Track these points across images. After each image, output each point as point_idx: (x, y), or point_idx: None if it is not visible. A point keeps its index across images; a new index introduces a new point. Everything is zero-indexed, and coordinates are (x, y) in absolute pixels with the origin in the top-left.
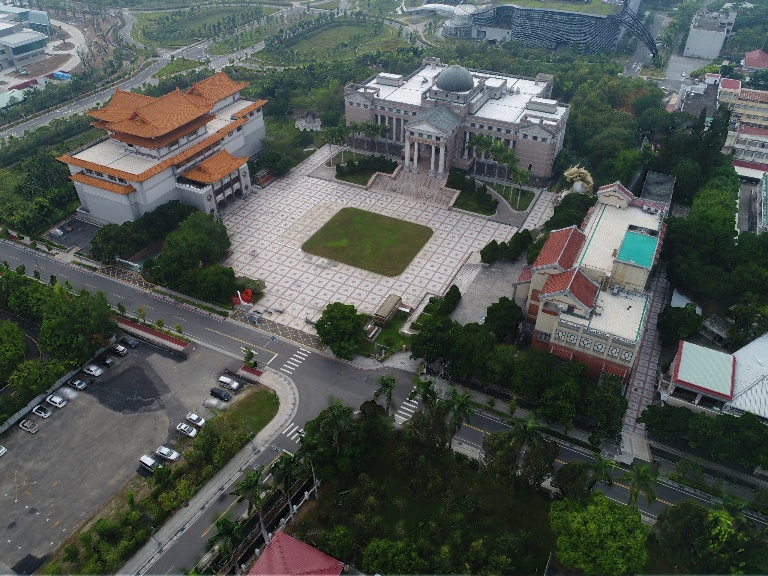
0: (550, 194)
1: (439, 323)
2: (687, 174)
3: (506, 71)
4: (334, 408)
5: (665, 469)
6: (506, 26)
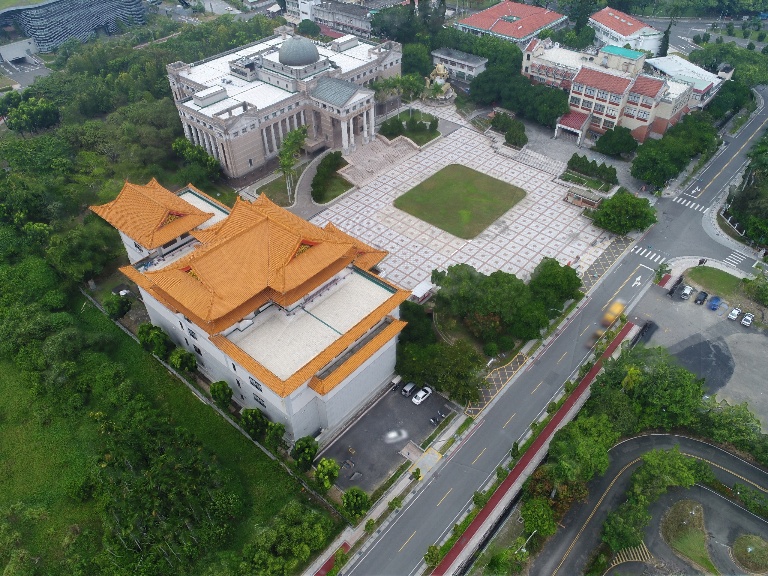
0: (413, 104)
1: (653, 154)
2: (451, 40)
3: (181, 57)
4: None
5: (726, 133)
6: (18, 36)
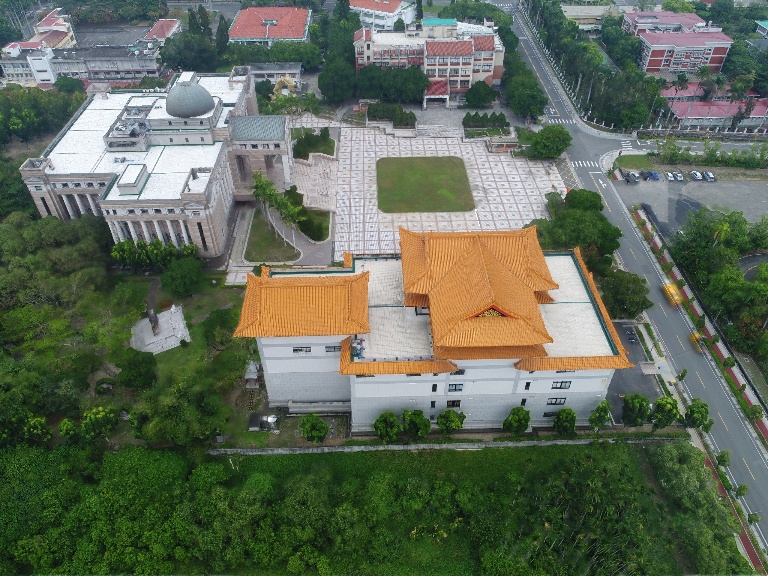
0: None
1: (528, 92)
2: (249, 55)
3: None
4: (643, 73)
5: None
6: None
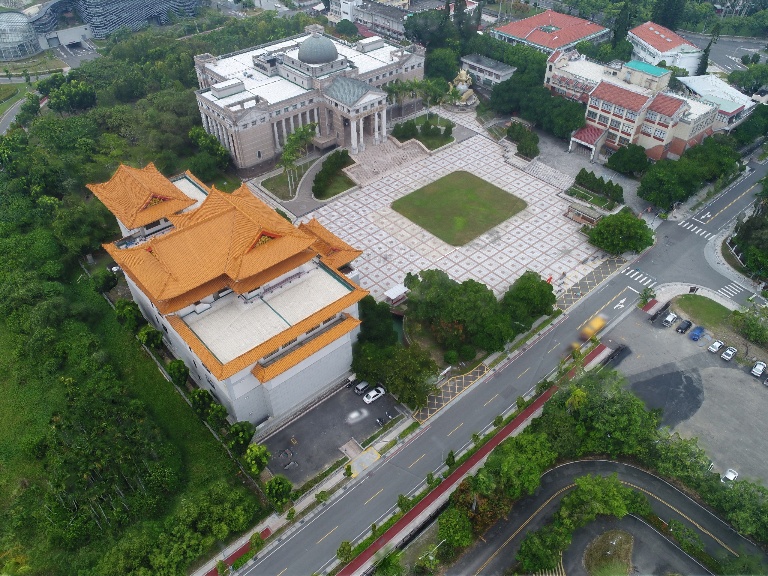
0: (434, 108)
1: (660, 174)
2: (482, 47)
3: None
4: None
5: (754, 159)
6: (76, 22)
